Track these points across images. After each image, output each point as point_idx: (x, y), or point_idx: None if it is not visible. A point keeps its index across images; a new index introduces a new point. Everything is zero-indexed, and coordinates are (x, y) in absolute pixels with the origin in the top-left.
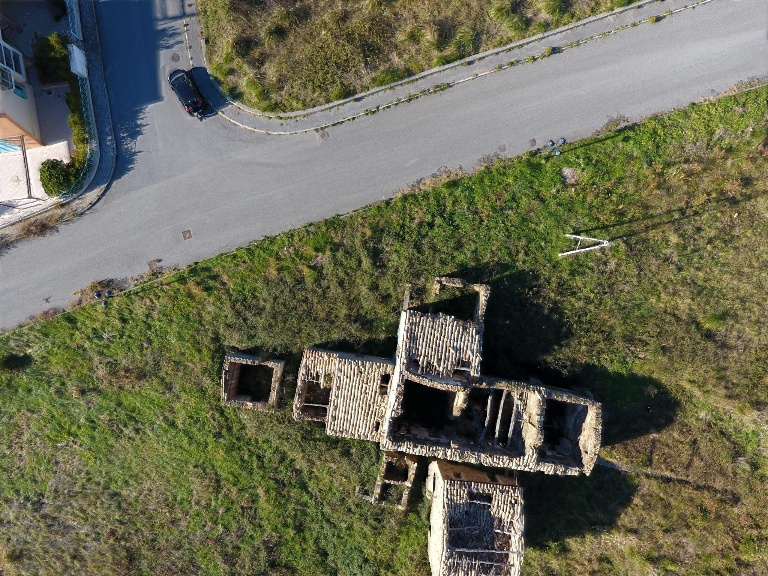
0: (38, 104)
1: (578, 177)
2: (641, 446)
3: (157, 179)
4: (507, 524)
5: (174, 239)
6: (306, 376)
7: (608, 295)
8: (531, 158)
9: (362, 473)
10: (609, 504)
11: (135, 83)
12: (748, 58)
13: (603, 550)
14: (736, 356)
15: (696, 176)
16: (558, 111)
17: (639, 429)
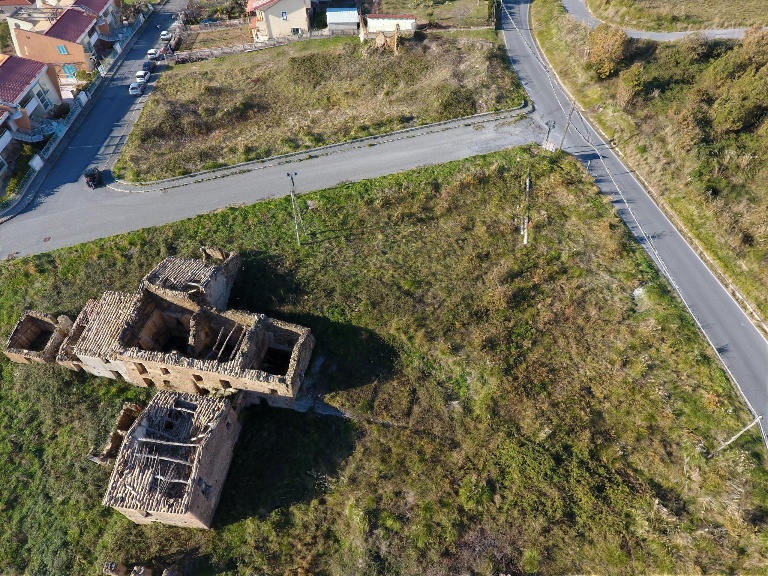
0: (1, 190)
1: (316, 205)
2: (364, 393)
3: (47, 214)
4: (203, 428)
5: (36, 242)
6: (82, 321)
7: (332, 268)
8: (288, 197)
9: (100, 427)
10: (333, 456)
11: (65, 175)
12: (422, 158)
13: (329, 522)
14: (432, 309)
15: (394, 206)
16: (310, 179)
17: (362, 378)
